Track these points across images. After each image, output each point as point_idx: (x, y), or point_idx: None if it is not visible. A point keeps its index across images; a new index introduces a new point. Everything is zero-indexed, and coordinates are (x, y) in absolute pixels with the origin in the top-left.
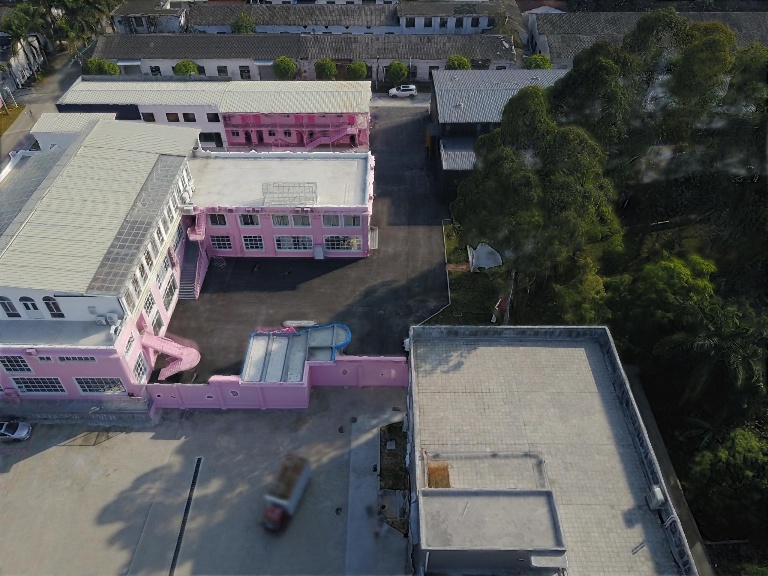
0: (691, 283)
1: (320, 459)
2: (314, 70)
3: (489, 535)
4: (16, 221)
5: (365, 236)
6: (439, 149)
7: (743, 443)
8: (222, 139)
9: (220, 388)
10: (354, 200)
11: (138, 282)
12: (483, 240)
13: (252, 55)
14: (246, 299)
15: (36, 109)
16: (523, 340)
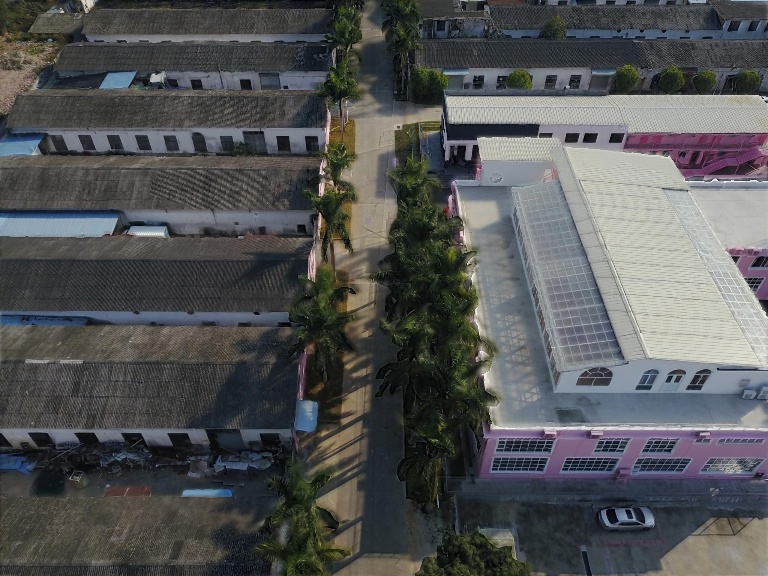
0: None
1: None
2: (651, 79)
3: None
4: (601, 275)
5: None
6: None
7: None
8: None
9: None
10: None
11: None
12: None
13: (589, 63)
14: None
15: (369, 124)
16: None
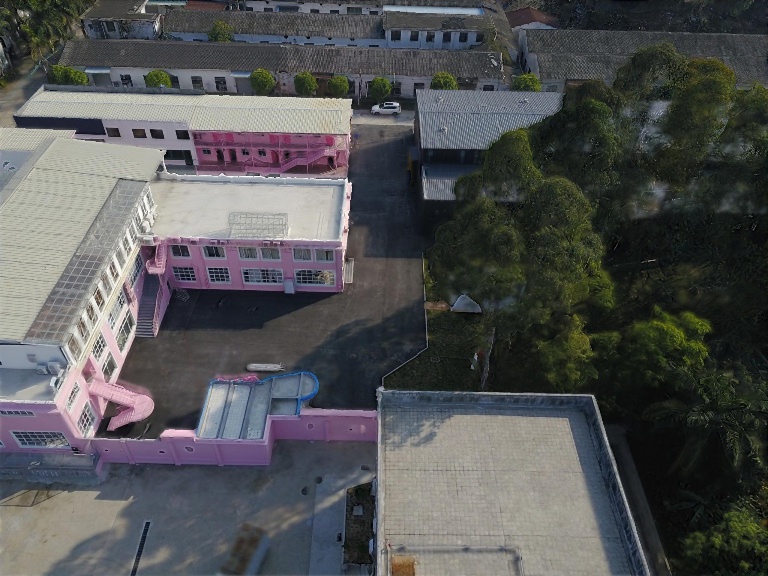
0: (685, 346)
1: (280, 526)
2: (294, 83)
3: None
4: None
5: (339, 271)
6: (421, 176)
7: (738, 527)
8: (192, 157)
9: (173, 444)
10: (328, 233)
11: (85, 326)
12: None
13: (228, 66)
14: (209, 338)
15: None
16: (502, 407)
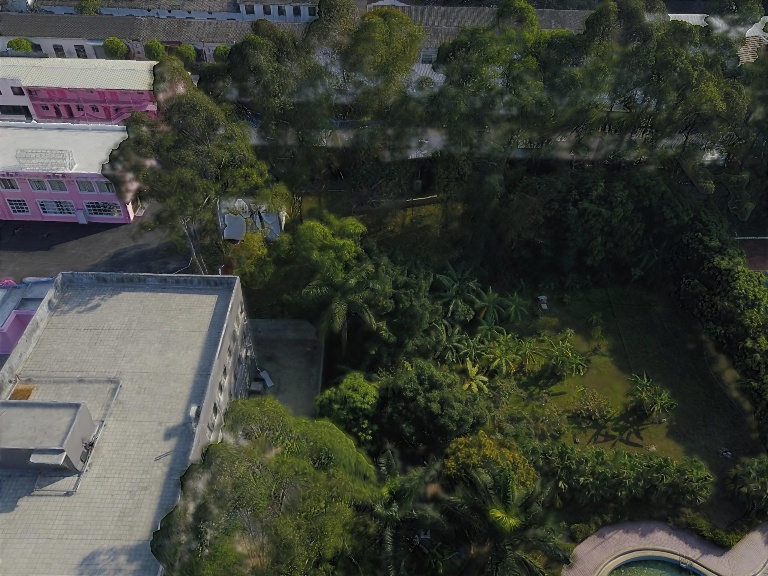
0: (331, 241)
1: None
2: None
3: (6, 437)
4: None
5: (122, 202)
6: None
7: (349, 382)
8: (31, 112)
9: None
10: None
11: None
12: (160, 199)
13: (85, 35)
14: None
15: None
16: (167, 287)
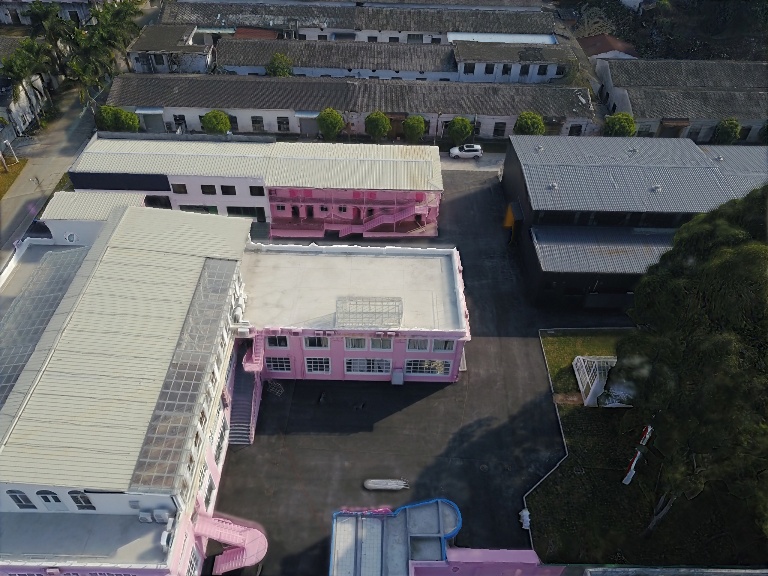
0: None
1: None
2: (363, 123)
3: None
4: (29, 367)
5: (457, 361)
6: (532, 241)
7: None
8: (265, 214)
9: None
10: (446, 318)
11: (192, 457)
12: None
13: (293, 105)
14: (314, 444)
15: (40, 165)
16: None
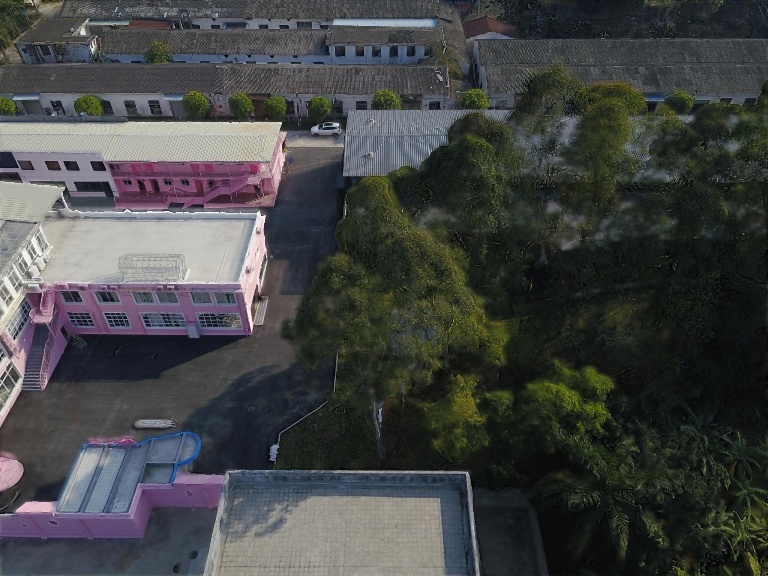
0: (578, 411)
1: None
2: None
3: None
4: None
5: (243, 314)
6: (343, 206)
7: None
8: (111, 188)
9: (32, 519)
10: (229, 274)
11: None
12: None
13: (161, 89)
14: (100, 390)
15: None
16: (367, 486)
